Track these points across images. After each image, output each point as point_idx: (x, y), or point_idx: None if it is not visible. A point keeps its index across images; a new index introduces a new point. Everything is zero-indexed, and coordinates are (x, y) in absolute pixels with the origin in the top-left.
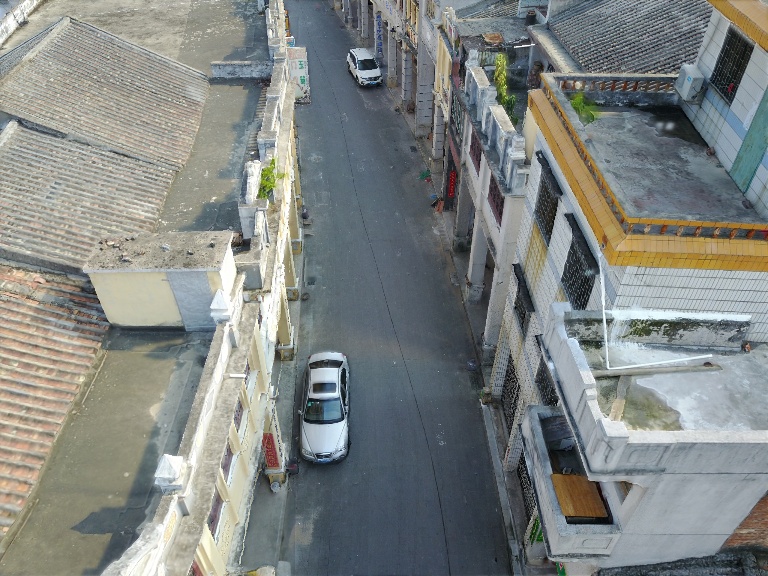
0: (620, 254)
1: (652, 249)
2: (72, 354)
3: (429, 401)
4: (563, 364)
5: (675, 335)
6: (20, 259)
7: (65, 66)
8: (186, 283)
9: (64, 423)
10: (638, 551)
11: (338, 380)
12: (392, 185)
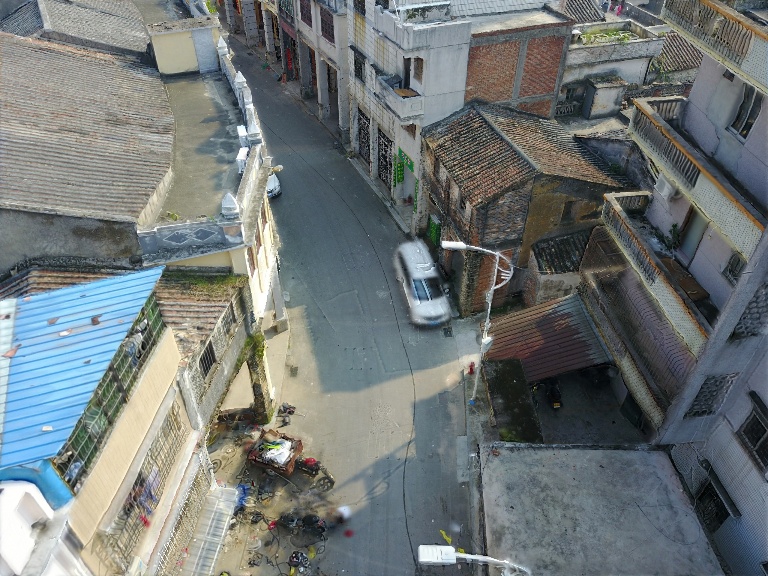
0: None
1: None
2: None
3: (318, 165)
4: (385, 23)
5: (425, 15)
6: (99, 47)
7: None
8: (201, 38)
9: None
10: (434, 110)
11: None
12: (245, 75)
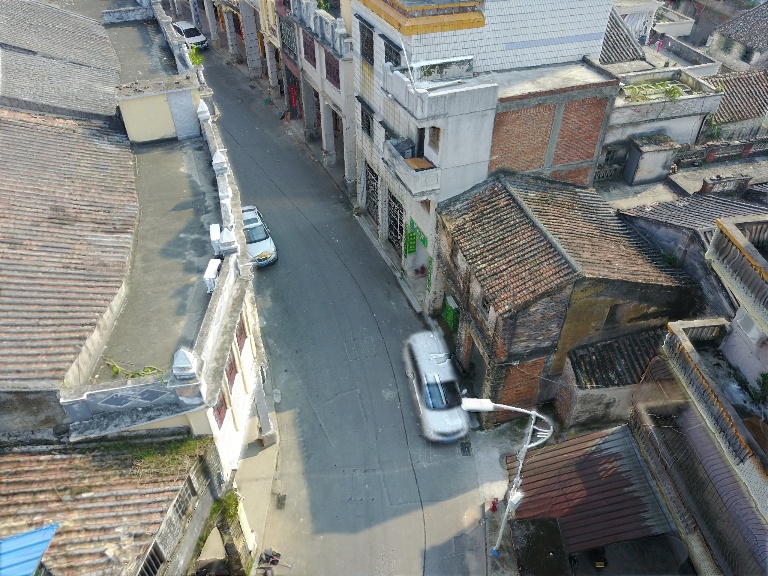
0: (407, 28)
1: (421, 23)
2: (118, 154)
3: (321, 223)
4: (395, 85)
5: (443, 73)
6: (58, 112)
7: (3, 15)
8: (178, 101)
9: (134, 181)
10: (452, 183)
11: (257, 216)
12: (245, 112)
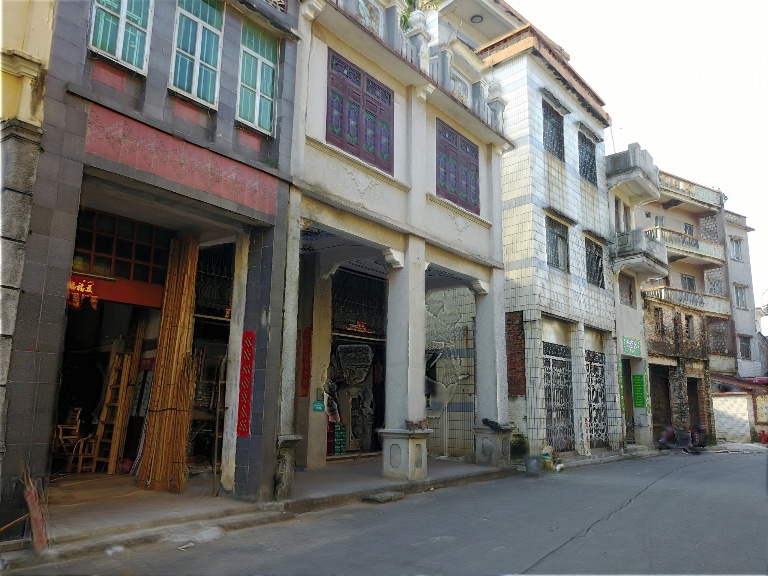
0: None
1: None
2: None
3: None
4: None
5: None
6: None
7: None
8: None
9: None
10: None
11: None
12: None
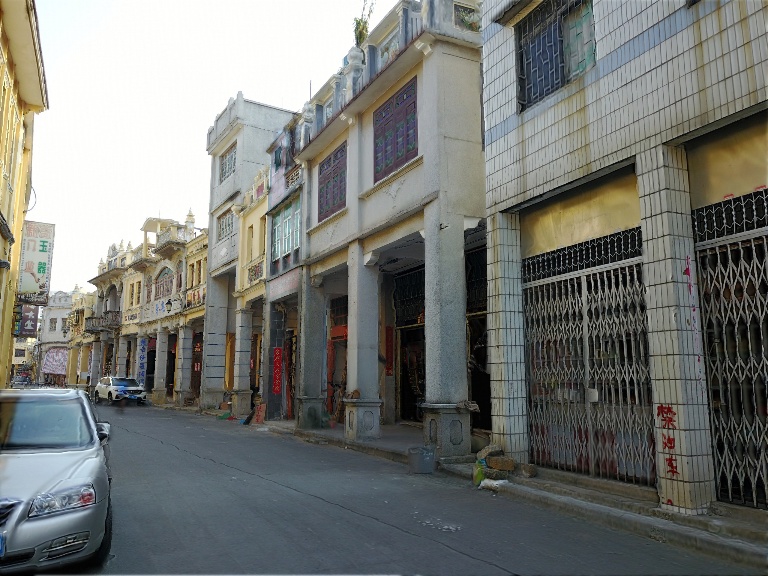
0: None
1: None
2: None
3: (356, 496)
4: None
5: None
6: None
7: None
8: None
9: None
10: None
11: None
12: None
